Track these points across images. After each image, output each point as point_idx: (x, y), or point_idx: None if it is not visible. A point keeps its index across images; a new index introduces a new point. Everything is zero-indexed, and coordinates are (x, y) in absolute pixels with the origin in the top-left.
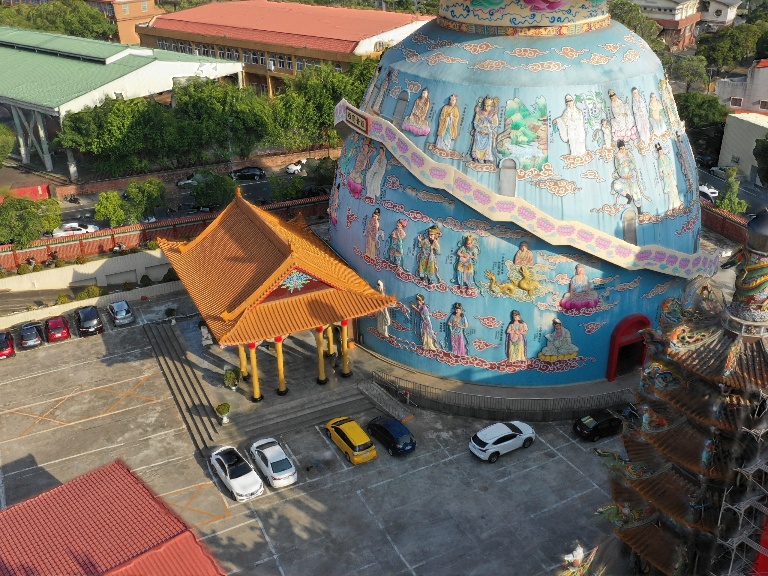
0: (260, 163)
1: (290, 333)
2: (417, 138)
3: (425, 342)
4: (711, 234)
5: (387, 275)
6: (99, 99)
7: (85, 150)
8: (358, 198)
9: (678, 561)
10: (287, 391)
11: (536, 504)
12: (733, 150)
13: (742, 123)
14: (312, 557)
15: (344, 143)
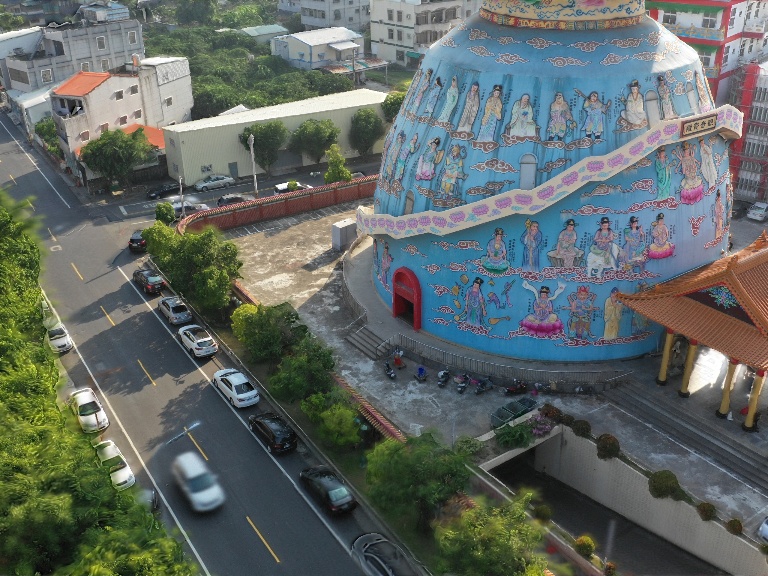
0: None
1: None
2: None
3: None
4: (359, 202)
5: None
6: None
7: None
8: None
9: None
10: None
11: None
12: (201, 161)
13: (202, 132)
14: None
15: (615, 187)
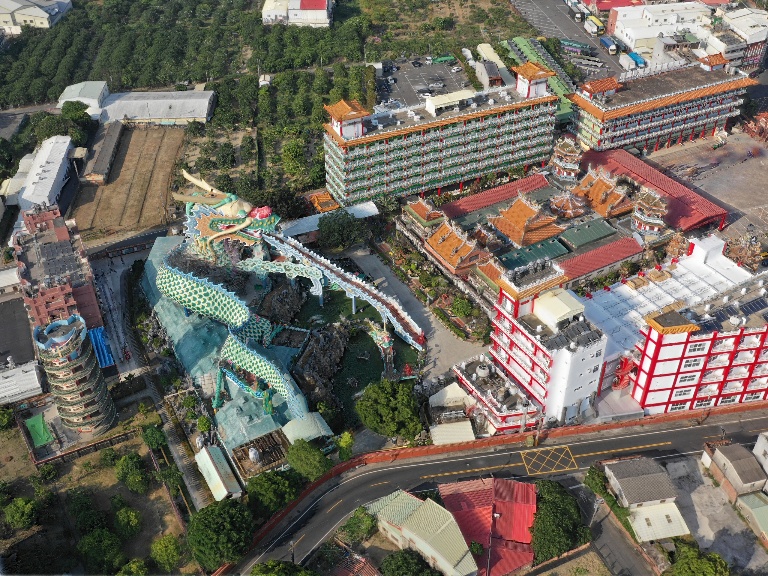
0: None
1: None
2: None
3: None
4: None
5: None
6: None
7: None
8: None
9: None
10: None
11: None
12: None
13: None
14: None
15: None
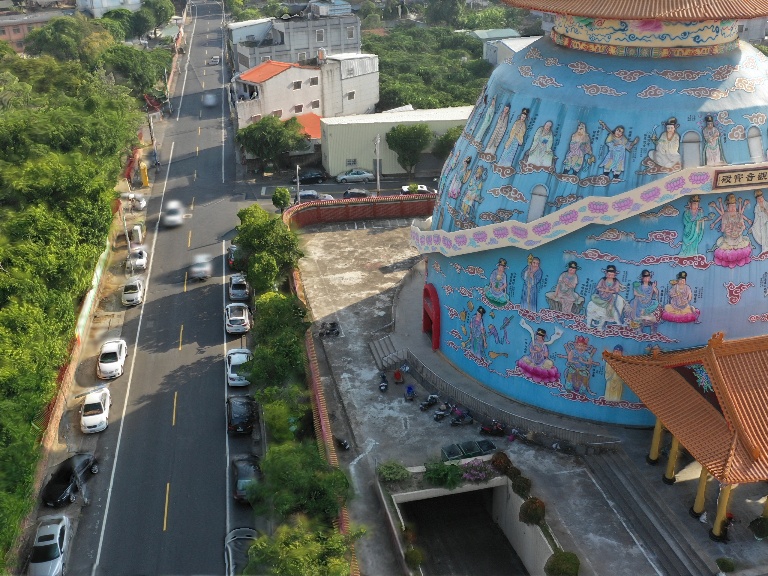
0: (44, 454)
1: None
2: None
3: None
4: None
5: None
6: None
7: None
8: (747, 263)
9: None
10: None
11: None
12: (346, 155)
13: (350, 127)
14: None
15: (627, 234)
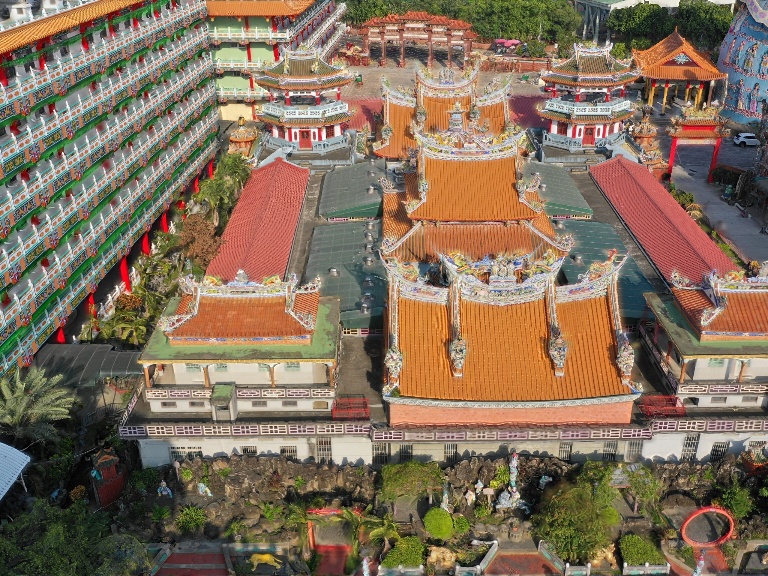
0: None
1: (673, 84)
2: (763, 2)
3: (739, 104)
4: None
5: (731, 70)
6: (635, 4)
7: (617, 29)
8: (731, 34)
9: None
10: (665, 114)
11: (749, 157)
12: None
13: None
14: None
15: None
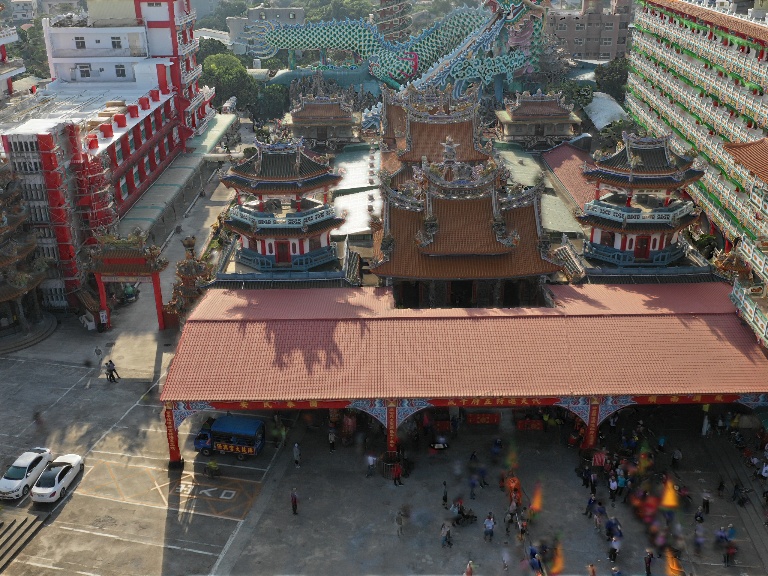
0: None
1: None
2: None
3: None
4: None
5: None
6: None
7: None
8: None
9: (48, 259)
10: None
11: None
12: None
13: None
14: (100, 416)
15: None
